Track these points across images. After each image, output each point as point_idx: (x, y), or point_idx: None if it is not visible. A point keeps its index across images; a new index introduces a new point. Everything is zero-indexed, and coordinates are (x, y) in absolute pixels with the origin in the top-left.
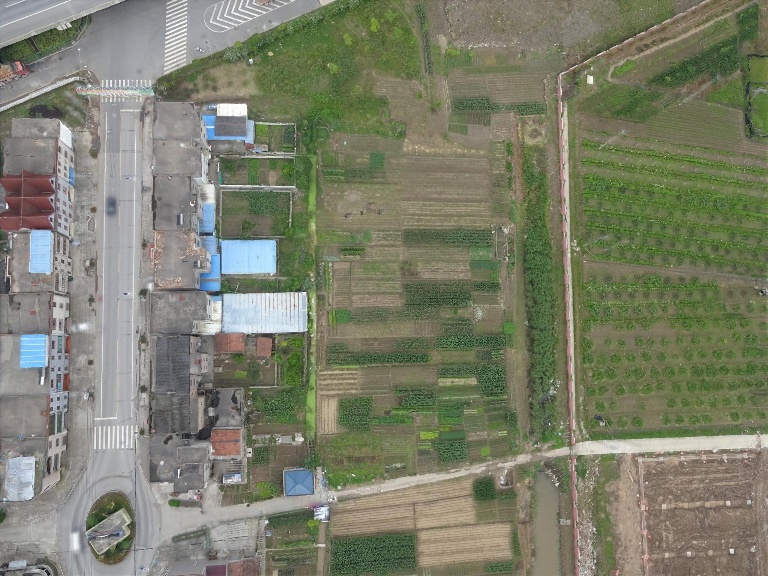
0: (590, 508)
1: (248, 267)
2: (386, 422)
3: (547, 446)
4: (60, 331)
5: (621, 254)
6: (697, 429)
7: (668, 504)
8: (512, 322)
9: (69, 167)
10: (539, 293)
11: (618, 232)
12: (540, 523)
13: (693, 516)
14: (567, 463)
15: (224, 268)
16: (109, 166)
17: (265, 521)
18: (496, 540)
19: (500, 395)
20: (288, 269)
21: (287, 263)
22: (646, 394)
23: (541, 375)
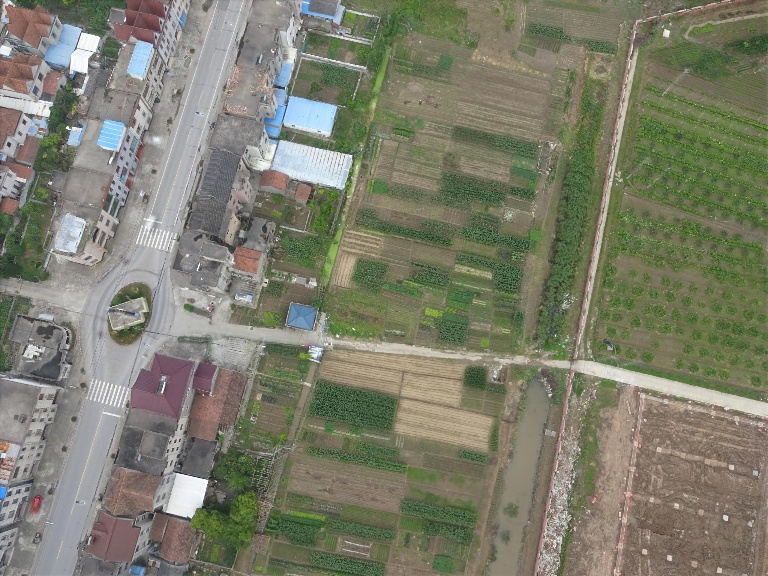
0: (579, 427)
1: (307, 122)
2: (396, 290)
3: (548, 354)
4: (137, 134)
5: (664, 194)
6: (711, 383)
7: (664, 448)
8: (539, 230)
9: (183, 11)
10: (572, 208)
11: (665, 174)
12: (524, 428)
13: (689, 468)
14: (565, 376)
15: (286, 118)
16: (215, 20)
17: (263, 345)
18: (476, 430)
19: (512, 293)
20: (342, 135)
21: (342, 130)
22: (663, 333)
23: (557, 285)
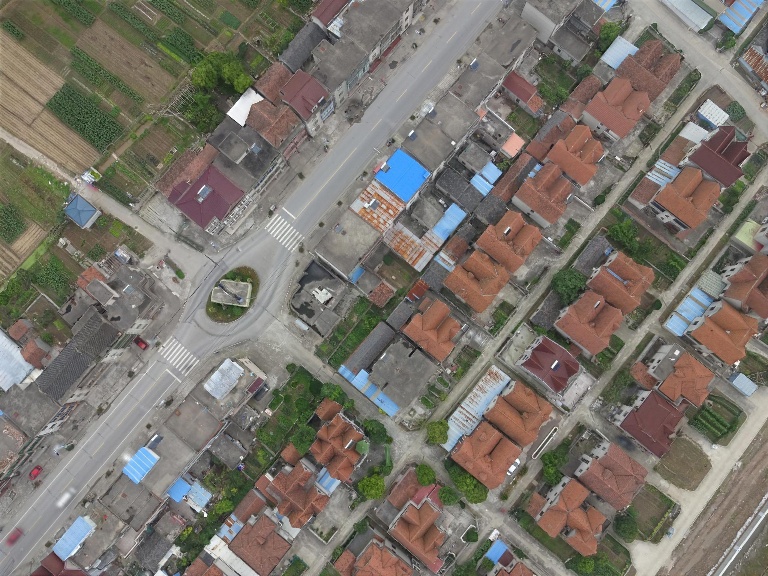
0: None
1: None
2: None
3: None
4: None
5: None
6: None
7: None
8: None
9: None
10: None
11: None
12: None
13: None
14: None
15: None
16: (8, 571)
17: None
18: None
19: None
20: None
21: None
22: None
23: None
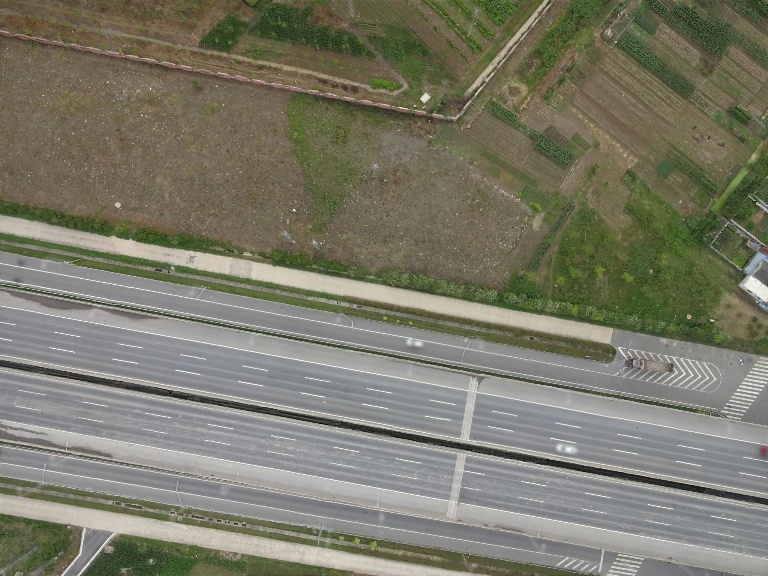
0: None
1: None
2: None
3: None
4: None
5: None
6: None
7: None
8: None
9: None
10: None
11: None
12: None
13: None
14: None
15: None
16: None
17: None
18: None
19: None
20: None
21: None
22: None
23: None
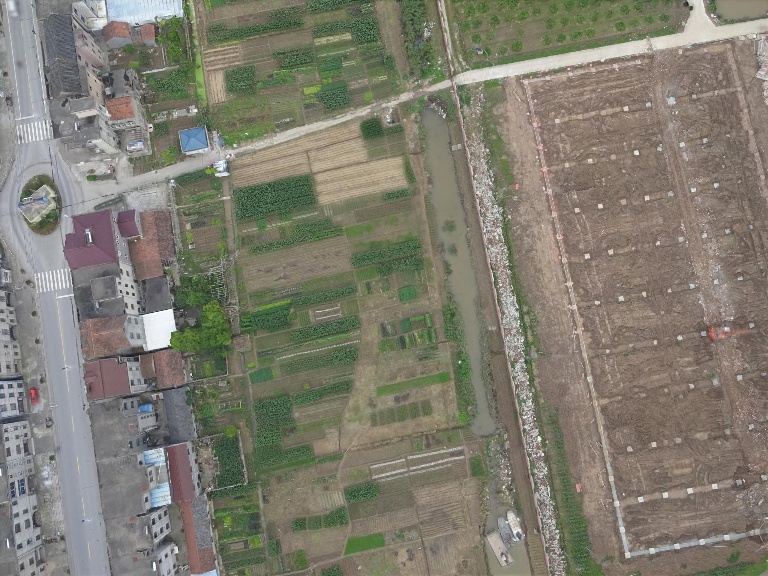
0: (480, 131)
1: None
2: (270, 84)
3: (428, 81)
4: None
5: None
6: (582, 45)
7: (561, 118)
8: None
9: None
10: None
11: None
12: (433, 154)
13: (589, 124)
14: (450, 94)
15: None
16: None
17: (172, 181)
18: (390, 172)
19: (374, 42)
20: None
21: None
22: (523, 20)
23: (411, 17)
